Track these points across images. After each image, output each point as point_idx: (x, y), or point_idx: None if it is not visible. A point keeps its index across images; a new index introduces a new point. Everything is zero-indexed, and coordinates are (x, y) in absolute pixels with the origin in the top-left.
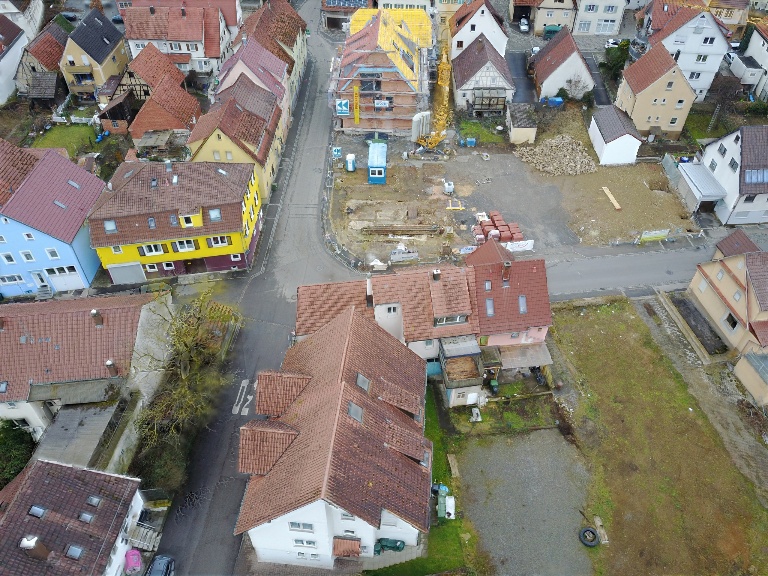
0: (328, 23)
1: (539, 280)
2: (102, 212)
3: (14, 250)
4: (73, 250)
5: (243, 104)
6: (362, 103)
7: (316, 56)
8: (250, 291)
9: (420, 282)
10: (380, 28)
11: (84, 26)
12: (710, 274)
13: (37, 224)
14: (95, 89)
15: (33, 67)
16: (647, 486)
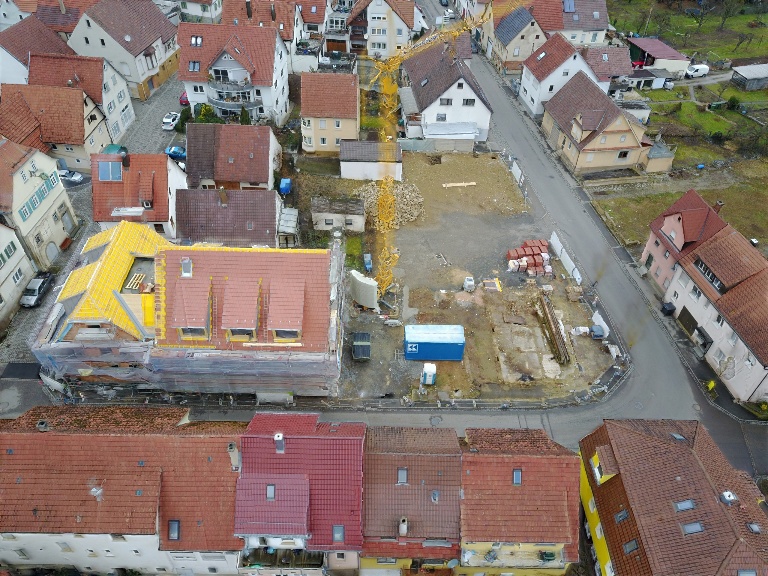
0: None
1: None
2: None
3: None
4: None
5: None
6: None
7: None
8: None
9: None
10: (258, 249)
11: None
12: (594, 147)
13: None
14: None
15: None
16: (765, 223)
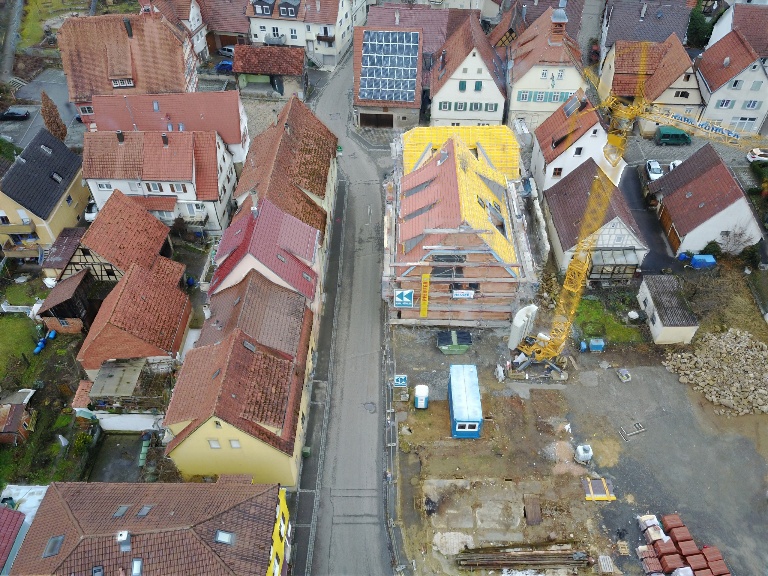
0: (361, 120)
1: None
2: None
3: None
4: None
5: (255, 334)
6: (432, 291)
7: (349, 175)
8: None
9: None
10: (459, 181)
11: (22, 163)
12: None
13: None
14: (40, 254)
15: None
16: None
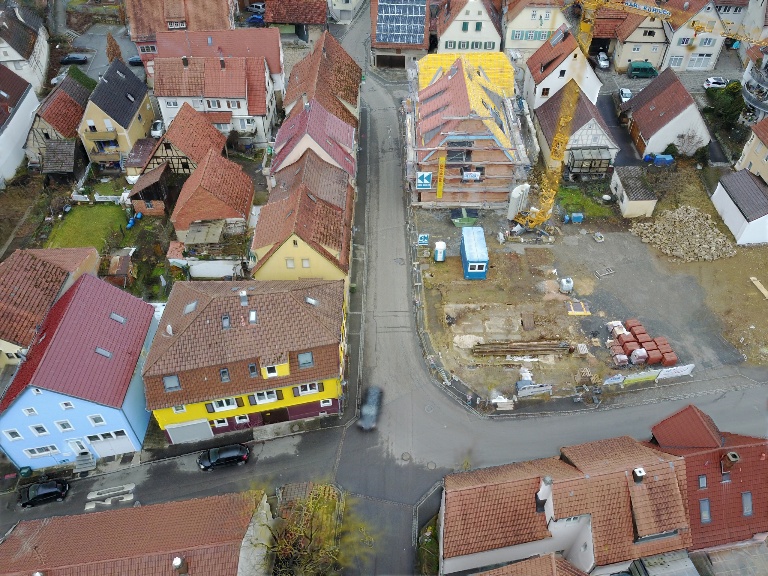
0: (377, 61)
1: (767, 470)
2: (161, 366)
3: (47, 421)
4: (123, 413)
5: (315, 191)
6: (447, 175)
7: (370, 103)
8: (347, 449)
9: (615, 485)
10: (468, 85)
11: (105, 83)
12: None
13: (78, 389)
14: (120, 158)
15: (46, 134)
16: None
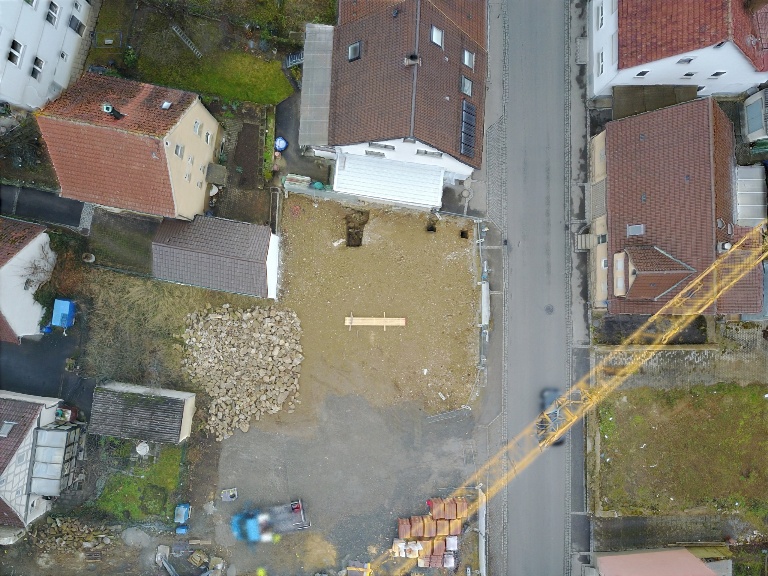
0: None
1: None
2: None
3: None
4: None
5: None
6: None
7: None
8: None
9: None
10: None
11: None
12: None
13: None
14: None
15: None
16: None
